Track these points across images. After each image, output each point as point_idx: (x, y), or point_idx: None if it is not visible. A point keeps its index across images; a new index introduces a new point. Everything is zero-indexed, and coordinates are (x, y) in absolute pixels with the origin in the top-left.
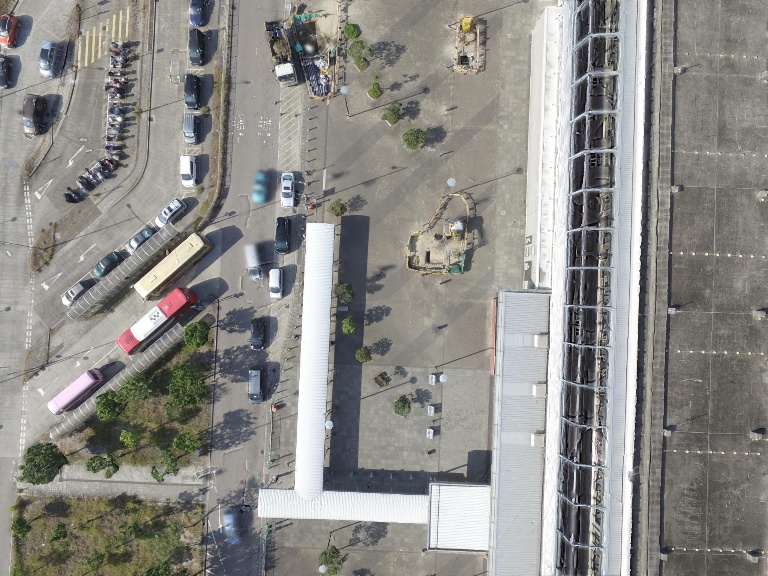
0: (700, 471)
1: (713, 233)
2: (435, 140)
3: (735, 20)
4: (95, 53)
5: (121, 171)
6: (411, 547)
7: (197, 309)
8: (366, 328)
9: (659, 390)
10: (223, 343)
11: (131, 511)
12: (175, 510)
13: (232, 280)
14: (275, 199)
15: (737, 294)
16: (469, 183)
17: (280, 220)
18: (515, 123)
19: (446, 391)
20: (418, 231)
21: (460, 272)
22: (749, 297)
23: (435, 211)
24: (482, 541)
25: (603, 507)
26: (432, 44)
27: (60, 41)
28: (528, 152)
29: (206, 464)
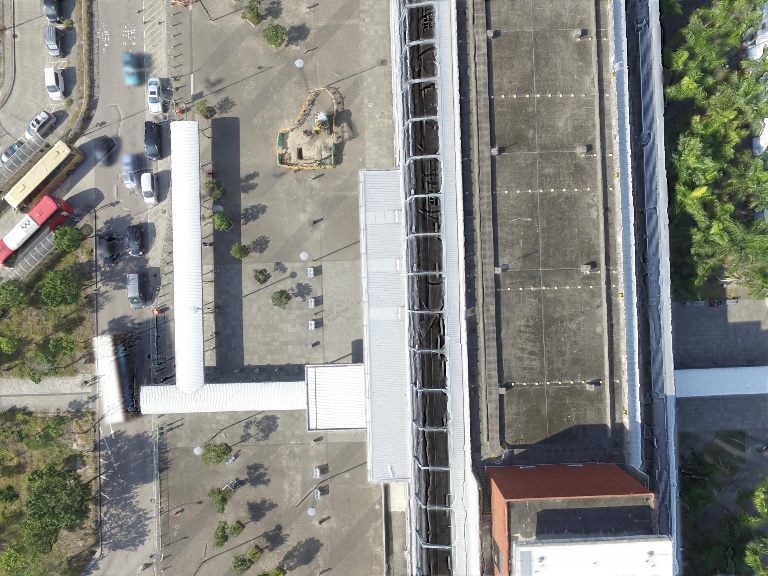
0: (535, 307)
1: (533, 75)
2: (299, 38)
3: None
4: None
5: None
6: (302, 439)
7: (74, 220)
8: (243, 227)
9: (488, 230)
10: (102, 252)
11: (21, 423)
12: (66, 419)
13: (107, 189)
14: (144, 107)
15: (560, 133)
16: (335, 78)
17: (147, 124)
18: (376, 16)
19: (326, 283)
20: (288, 128)
21: (330, 164)
22: (572, 135)
23: (303, 107)
24: (361, 419)
25: (443, 350)
26: None
27: None
28: (391, 43)
29: (94, 372)
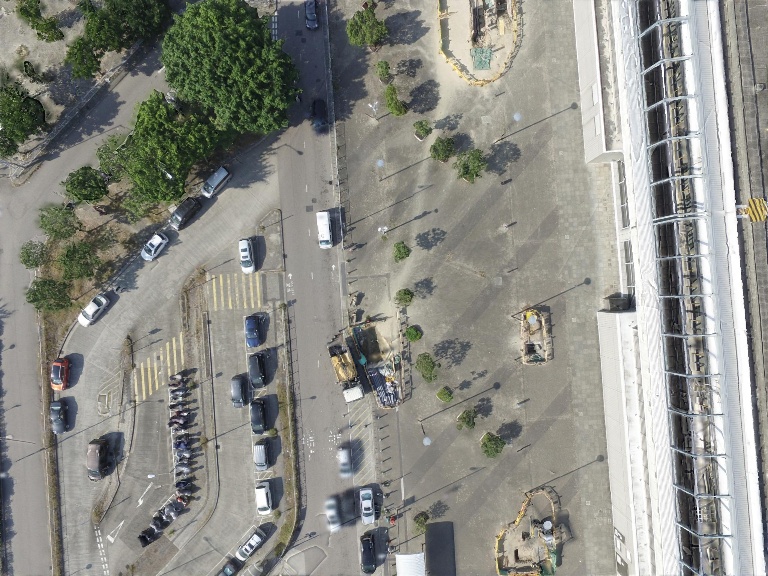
0: None
1: None
2: (511, 435)
3: None
4: (152, 385)
5: (194, 505)
6: None
7: None
8: None
9: None
10: None
11: None
12: None
13: None
14: (355, 515)
15: None
16: (550, 476)
17: (365, 545)
18: (590, 409)
19: None
20: (504, 531)
21: (553, 574)
22: None
23: (519, 510)
24: None
25: None
26: (497, 337)
27: (114, 376)
28: (607, 438)
29: None
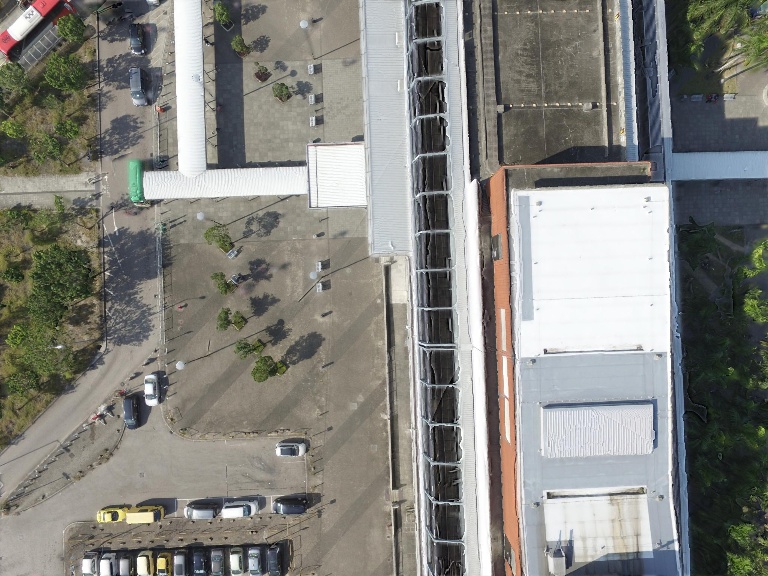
0: (532, 31)
1: None
2: None
3: None
4: None
5: None
6: (303, 234)
7: None
8: (244, 27)
9: None
10: (105, 53)
11: None
12: (70, 216)
13: None
14: None
15: None
16: None
17: None
18: None
19: (326, 81)
20: None
21: None
22: None
23: None
24: (361, 197)
25: (442, 74)
26: None
27: None
28: None
29: (97, 170)
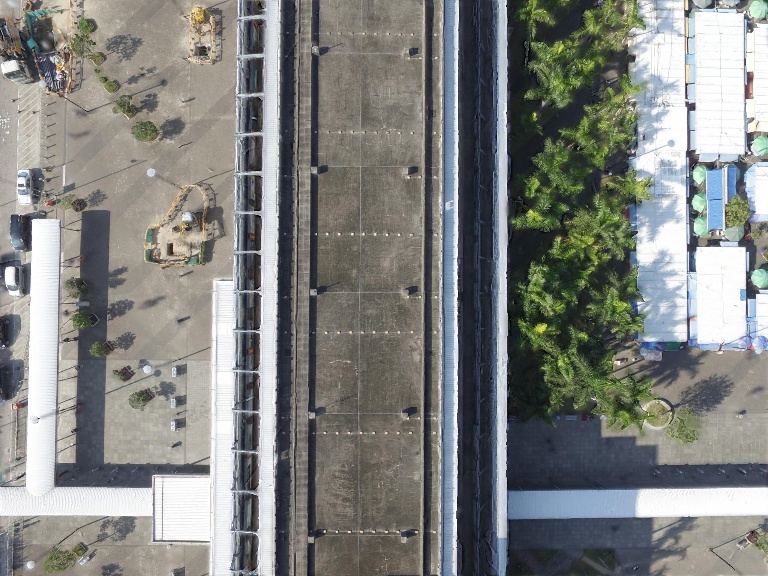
0: (351, 452)
1: (359, 213)
2: (174, 132)
3: None
4: None
5: None
6: None
7: None
8: (109, 323)
9: (303, 372)
10: None
11: None
12: None
13: None
14: (15, 197)
15: (384, 273)
16: (208, 174)
17: (13, 217)
18: None
19: (190, 383)
20: None
21: (197, 263)
22: (397, 276)
23: (174, 203)
24: (207, 532)
25: (256, 492)
26: (168, 36)
27: None
28: None
29: None
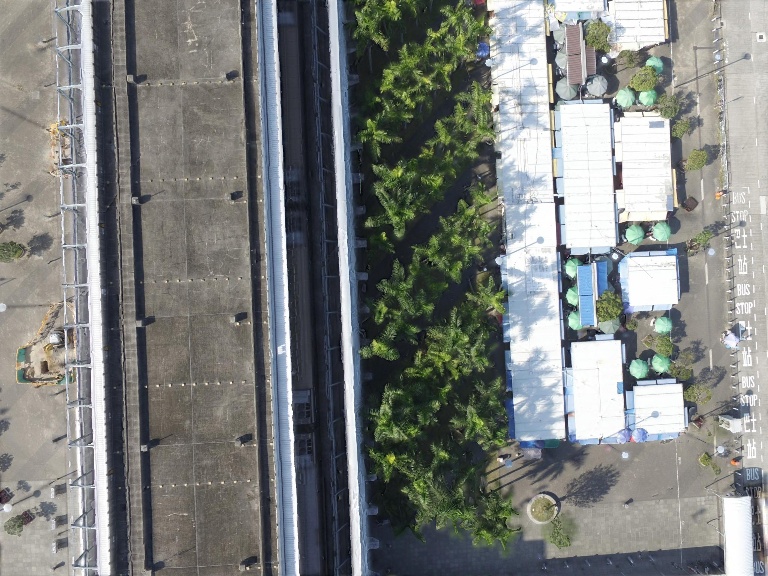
0: None
1: (189, 362)
2: (42, 248)
3: (198, 142)
4: None
5: None
6: None
7: None
8: None
9: (137, 529)
10: None
11: None
12: None
13: None
14: None
15: (217, 423)
16: None
17: None
18: None
19: (71, 502)
20: None
21: None
22: (230, 424)
23: None
24: None
25: None
26: (32, 150)
27: None
28: None
29: None
